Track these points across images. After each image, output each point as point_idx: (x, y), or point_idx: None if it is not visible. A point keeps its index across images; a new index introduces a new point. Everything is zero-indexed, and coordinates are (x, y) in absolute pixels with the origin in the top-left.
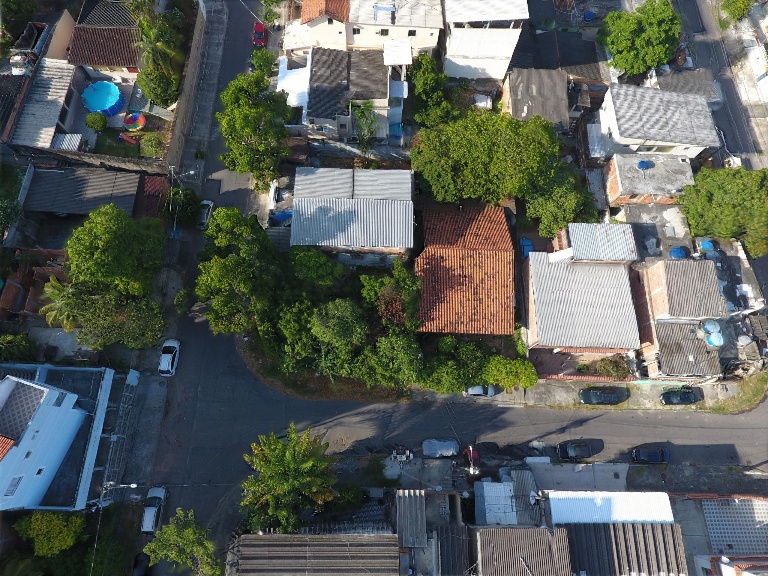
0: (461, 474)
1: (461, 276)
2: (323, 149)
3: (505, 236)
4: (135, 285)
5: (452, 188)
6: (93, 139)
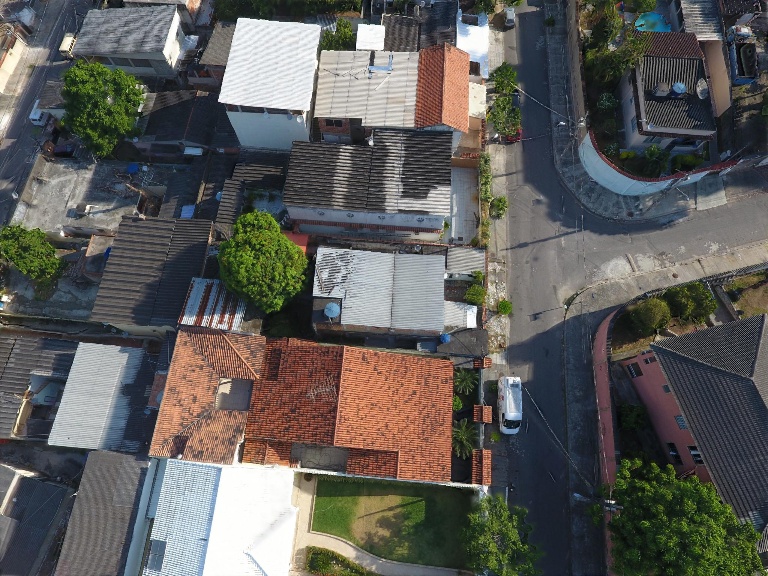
0: None
1: None
2: None
3: None
4: None
5: None
6: None
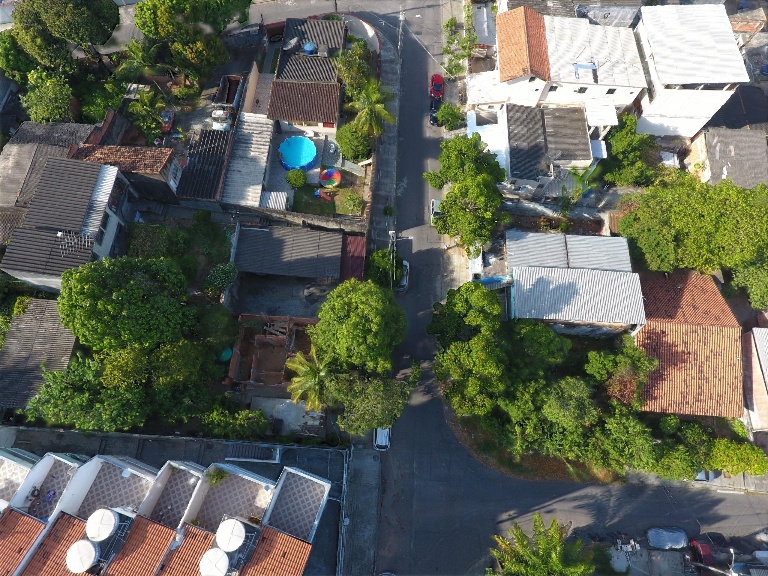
0: (690, 568)
1: (685, 352)
2: (513, 208)
3: (725, 310)
4: (385, 364)
5: (672, 258)
6: (291, 195)
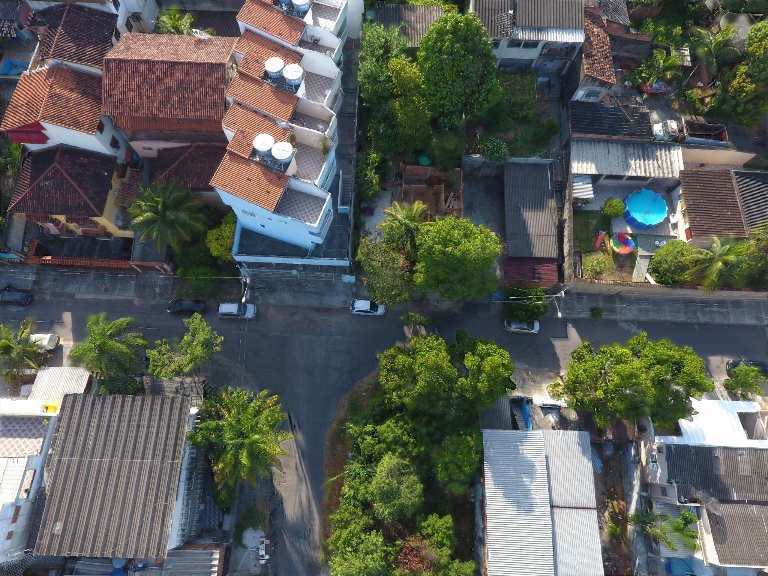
0: None
1: None
2: (628, 460)
3: None
4: (420, 279)
5: None
6: (593, 207)
